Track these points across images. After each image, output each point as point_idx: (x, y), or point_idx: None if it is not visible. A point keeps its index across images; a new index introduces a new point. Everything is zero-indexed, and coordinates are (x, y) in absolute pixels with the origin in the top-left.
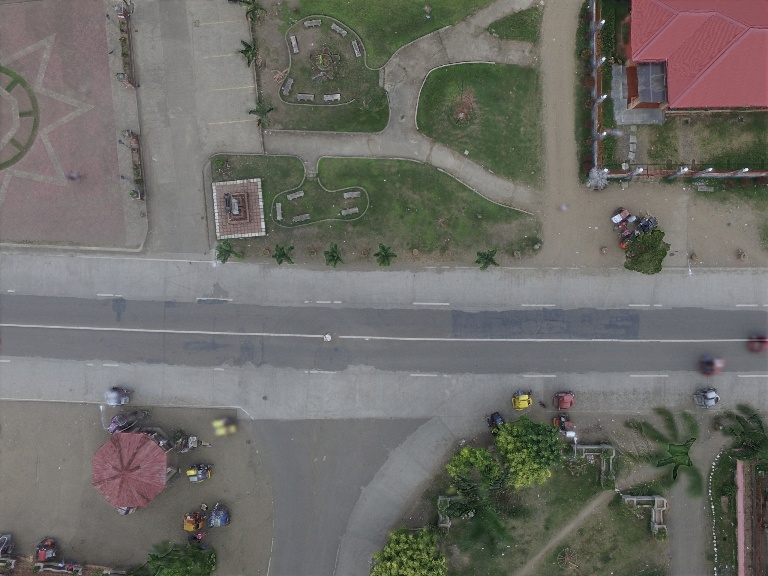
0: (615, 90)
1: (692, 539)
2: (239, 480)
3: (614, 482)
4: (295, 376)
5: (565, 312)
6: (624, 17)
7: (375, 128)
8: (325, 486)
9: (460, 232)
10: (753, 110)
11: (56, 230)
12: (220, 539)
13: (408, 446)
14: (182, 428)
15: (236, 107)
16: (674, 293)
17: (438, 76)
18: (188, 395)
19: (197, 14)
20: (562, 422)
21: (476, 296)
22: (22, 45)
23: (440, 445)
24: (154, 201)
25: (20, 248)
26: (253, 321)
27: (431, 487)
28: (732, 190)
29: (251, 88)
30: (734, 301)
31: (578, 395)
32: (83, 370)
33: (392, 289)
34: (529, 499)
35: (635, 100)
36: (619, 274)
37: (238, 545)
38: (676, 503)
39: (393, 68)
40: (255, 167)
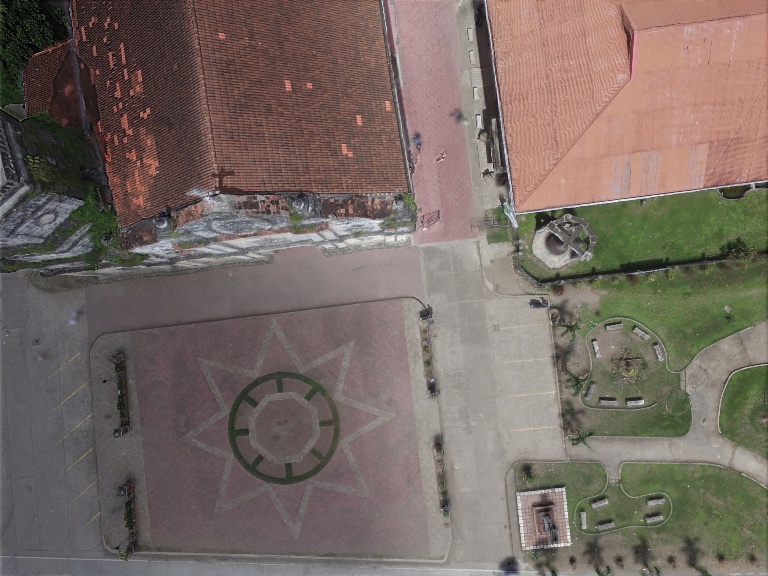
0: None
1: None
2: None
3: None
4: None
5: None
6: None
7: (678, 433)
8: None
9: (764, 538)
10: None
11: (359, 542)
12: None
13: None
14: None
15: (538, 413)
16: None
17: (740, 379)
18: None
19: (497, 318)
20: None
21: None
22: (320, 352)
23: None
24: (456, 510)
25: (322, 560)
26: None
27: None
28: None
29: (553, 393)
30: None
31: None
32: None
33: None
34: None
35: None
36: None
37: None
38: None
39: (694, 370)
40: (557, 474)
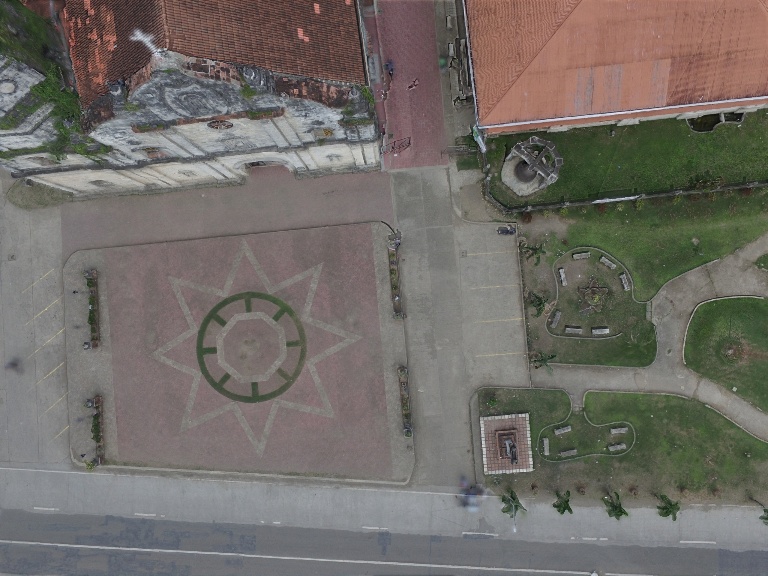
0: None
1: None
2: None
3: None
4: None
5: None
6: None
7: (642, 362)
8: None
9: (727, 470)
10: None
11: (323, 462)
12: None
13: None
14: None
15: (503, 339)
16: None
17: (706, 311)
18: None
19: (465, 244)
20: None
21: (743, 535)
22: (289, 273)
23: None
24: (420, 433)
25: (286, 479)
26: (519, 557)
27: None
28: None
29: (518, 320)
30: None
31: None
32: None
33: (658, 526)
34: None
35: None
36: None
37: None
38: None
39: (660, 301)
40: (522, 400)
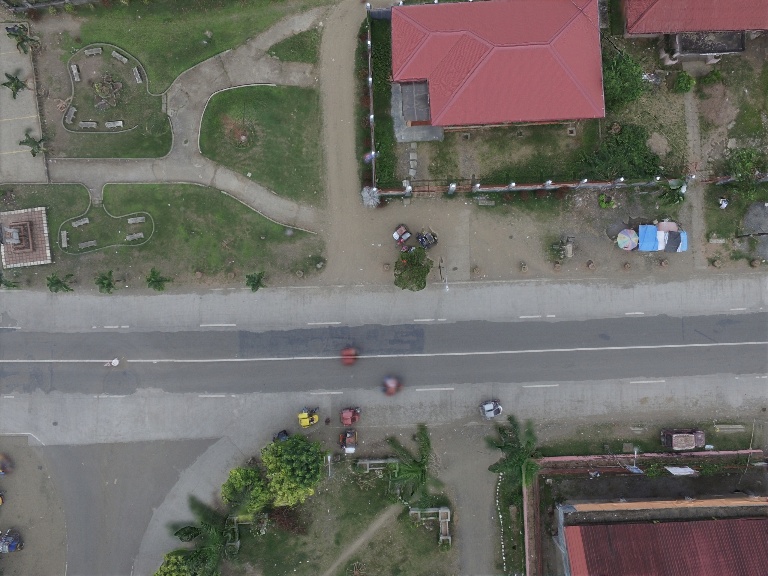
0: (395, 108)
1: (481, 549)
2: (32, 506)
3: (396, 496)
4: (84, 401)
5: (351, 329)
6: None
7: (158, 153)
8: (117, 509)
9: (245, 253)
10: (530, 124)
11: None
12: (14, 564)
13: (198, 467)
14: None
15: (20, 137)
16: (458, 307)
17: (220, 100)
18: None
19: None
20: (344, 438)
21: (262, 316)
22: None
23: (230, 464)
24: None
25: None
26: (41, 348)
27: (222, 506)
28: (513, 203)
29: (34, 118)
30: (518, 313)
31: (365, 411)
32: None
33: (179, 312)
34: (319, 515)
35: None
36: (403, 290)
37: (32, 570)
38: (465, 514)
39: (175, 93)
40: (40, 196)
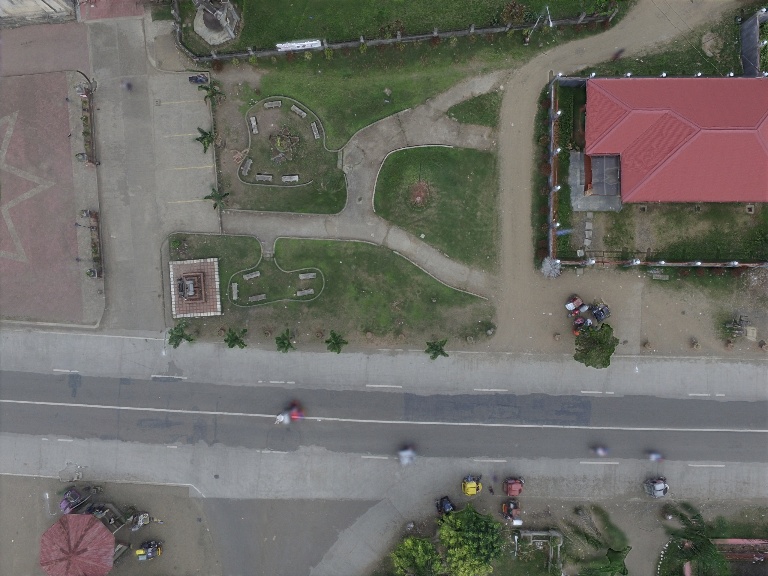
0: (572, 176)
1: None
2: (189, 557)
3: (560, 571)
4: (247, 455)
5: (517, 397)
6: (583, 104)
7: (332, 210)
8: (274, 565)
9: (414, 315)
10: None
11: (14, 305)
12: None
13: (358, 528)
14: (134, 504)
15: (195, 186)
16: (627, 381)
17: (396, 159)
18: (141, 472)
19: (159, 93)
20: (510, 509)
21: (429, 379)
22: None
23: (390, 527)
24: (112, 278)
25: None
26: (207, 400)
27: (380, 569)
28: (687, 279)
29: (210, 168)
30: (687, 390)
31: (528, 481)
32: (38, 444)
33: (345, 371)
34: None
35: (590, 190)
36: (572, 360)
37: None
38: None
39: (352, 150)
40: (212, 246)
